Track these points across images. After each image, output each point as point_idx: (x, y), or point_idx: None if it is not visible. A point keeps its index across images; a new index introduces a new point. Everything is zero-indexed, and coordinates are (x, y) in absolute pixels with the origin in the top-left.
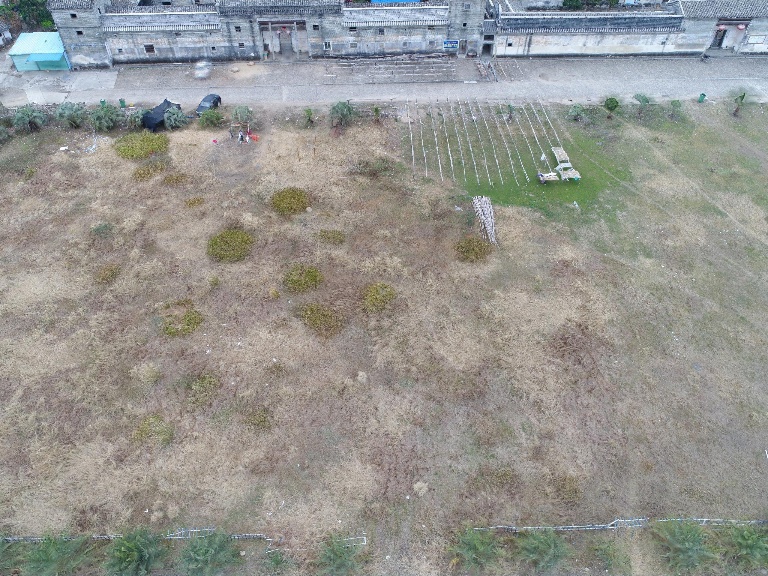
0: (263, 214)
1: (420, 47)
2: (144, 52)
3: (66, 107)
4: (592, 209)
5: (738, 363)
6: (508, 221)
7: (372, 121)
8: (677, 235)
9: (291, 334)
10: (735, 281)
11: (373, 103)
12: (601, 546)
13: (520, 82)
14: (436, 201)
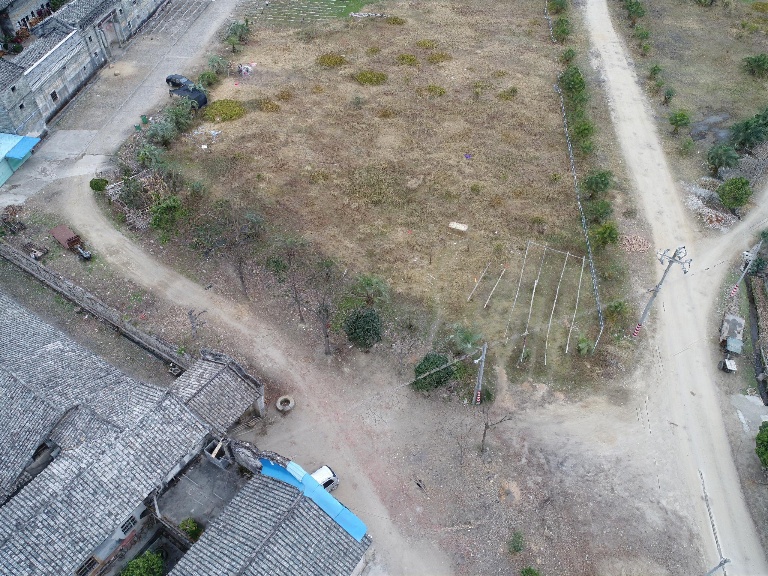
0: (342, 68)
1: None
2: (52, 103)
3: (160, 127)
4: None
5: None
6: None
7: None
8: None
9: (448, 65)
10: None
11: (220, 29)
12: None
13: None
14: None
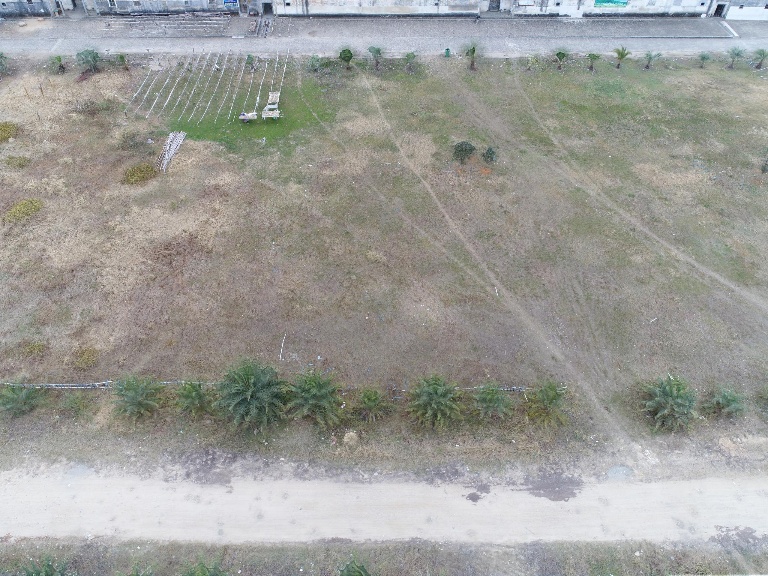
0: None
1: (202, 5)
2: None
3: None
4: (276, 144)
5: (314, 267)
6: (190, 152)
7: (122, 69)
8: (339, 166)
9: None
10: (364, 204)
11: (134, 54)
12: (83, 401)
13: (286, 38)
14: (135, 135)
